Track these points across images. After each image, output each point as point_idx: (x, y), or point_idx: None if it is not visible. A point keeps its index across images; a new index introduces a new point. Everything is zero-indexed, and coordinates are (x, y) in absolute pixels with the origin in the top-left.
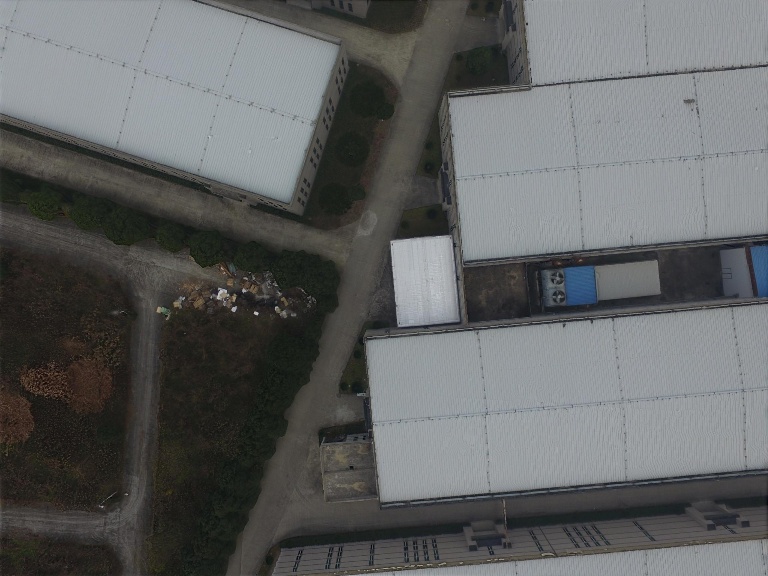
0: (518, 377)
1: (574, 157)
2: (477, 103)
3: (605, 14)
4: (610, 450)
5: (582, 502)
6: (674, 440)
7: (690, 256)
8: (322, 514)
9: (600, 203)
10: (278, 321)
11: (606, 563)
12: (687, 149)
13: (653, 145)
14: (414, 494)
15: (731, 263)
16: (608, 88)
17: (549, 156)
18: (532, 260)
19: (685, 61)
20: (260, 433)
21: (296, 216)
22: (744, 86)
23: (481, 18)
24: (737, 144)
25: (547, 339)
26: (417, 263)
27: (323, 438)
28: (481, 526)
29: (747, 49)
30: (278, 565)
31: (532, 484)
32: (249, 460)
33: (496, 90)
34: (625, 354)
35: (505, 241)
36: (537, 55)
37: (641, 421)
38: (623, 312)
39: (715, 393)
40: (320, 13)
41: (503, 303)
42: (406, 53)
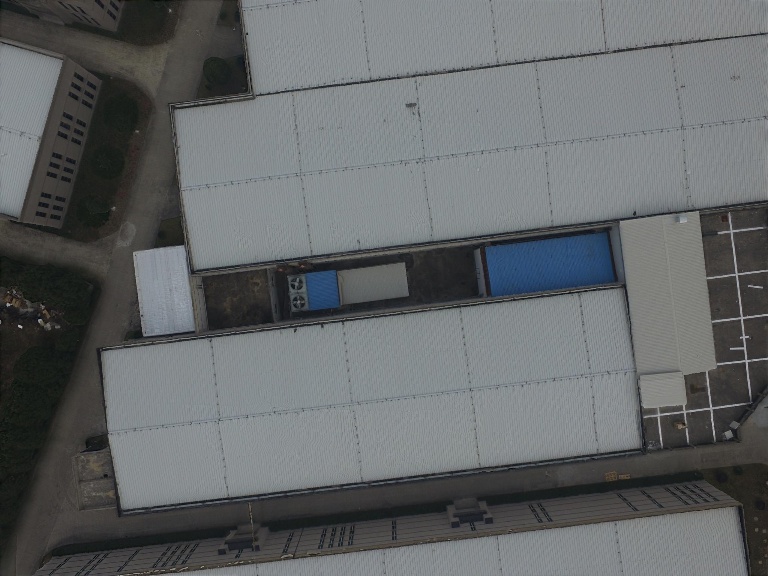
0: (250, 383)
1: (297, 164)
2: (202, 114)
3: (324, 21)
4: (353, 452)
5: (347, 503)
6: (411, 440)
7: (445, 257)
8: (93, 522)
9: (325, 209)
10: (41, 333)
11: (345, 563)
12: (408, 153)
13: (375, 150)
14: (154, 501)
15: (478, 263)
16: (331, 95)
17: (272, 164)
18: (262, 267)
19: (406, 65)
20: (7, 445)
21: (55, 229)
22: (465, 88)
23: (231, 27)
24: (458, 146)
25: (279, 344)
26: (160, 273)
27: (89, 447)
28: (246, 529)
29: (467, 51)
30: (35, 573)
31: (271, 487)
32: (0, 472)
33: (220, 100)
34: (355, 357)
35: (234, 249)
36: (263, 64)
37: (372, 423)
38: (350, 316)
39: (443, 393)
40: (73, 28)
41: (247, 310)
42: (159, 65)
